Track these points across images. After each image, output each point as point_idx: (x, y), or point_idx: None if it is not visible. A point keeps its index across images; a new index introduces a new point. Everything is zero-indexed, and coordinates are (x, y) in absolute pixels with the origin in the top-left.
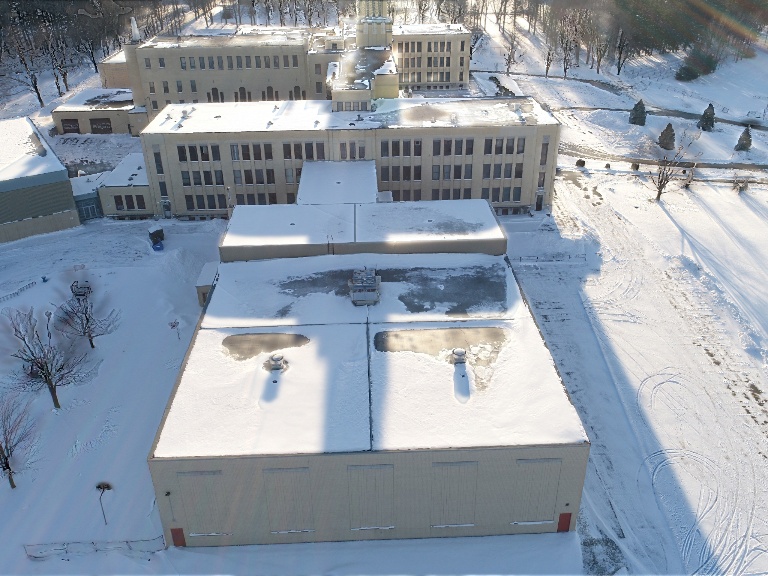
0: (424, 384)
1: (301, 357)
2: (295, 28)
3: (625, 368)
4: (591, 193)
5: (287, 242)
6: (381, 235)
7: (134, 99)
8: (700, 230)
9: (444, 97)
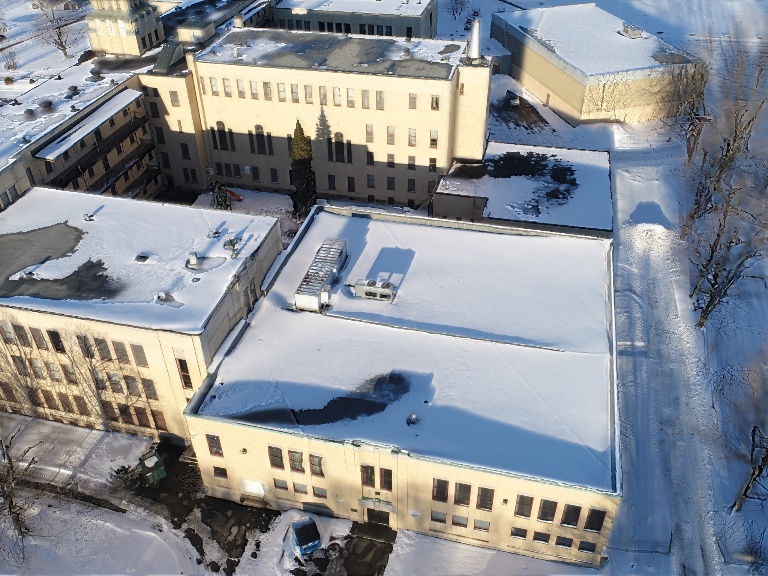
0: None
1: None
2: (42, 298)
3: None
4: None
5: None
6: None
7: (486, 136)
8: (88, 43)
9: (179, 2)
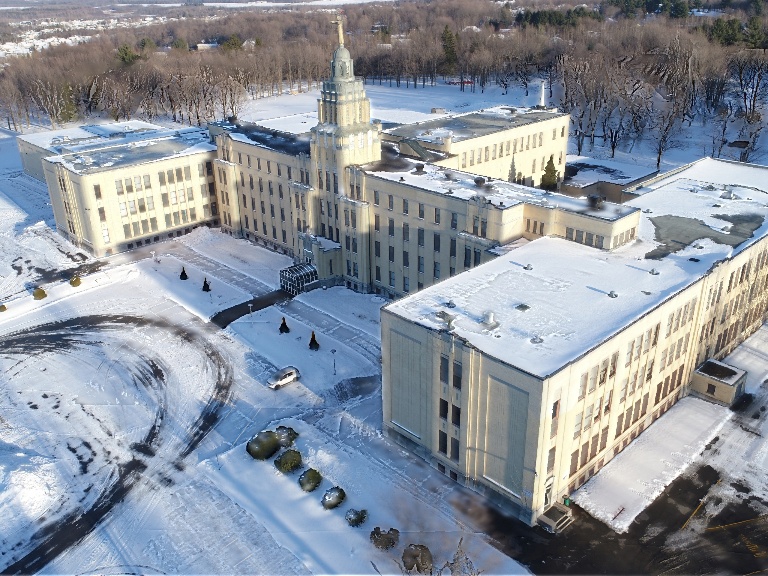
0: (75, 135)
1: (122, 131)
2: (760, 227)
3: (4, 201)
4: (25, 266)
5: (167, 131)
6: (128, 139)
7: None
8: None
9: (169, 158)
